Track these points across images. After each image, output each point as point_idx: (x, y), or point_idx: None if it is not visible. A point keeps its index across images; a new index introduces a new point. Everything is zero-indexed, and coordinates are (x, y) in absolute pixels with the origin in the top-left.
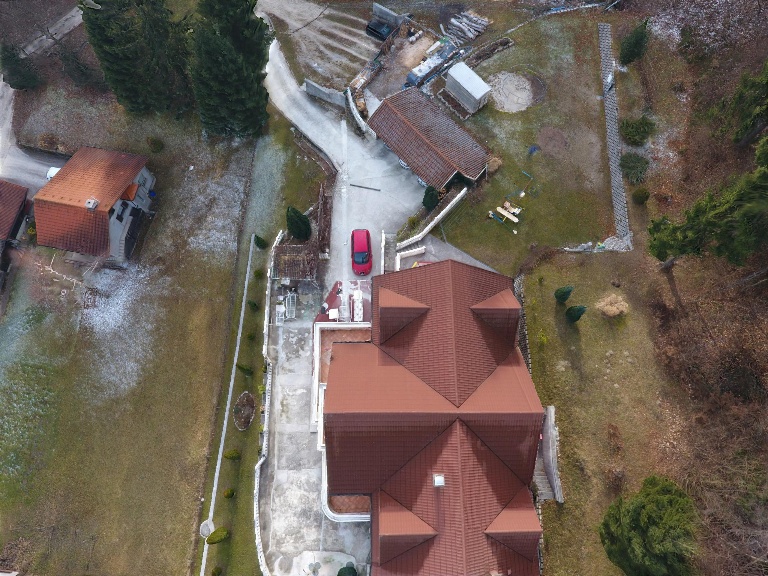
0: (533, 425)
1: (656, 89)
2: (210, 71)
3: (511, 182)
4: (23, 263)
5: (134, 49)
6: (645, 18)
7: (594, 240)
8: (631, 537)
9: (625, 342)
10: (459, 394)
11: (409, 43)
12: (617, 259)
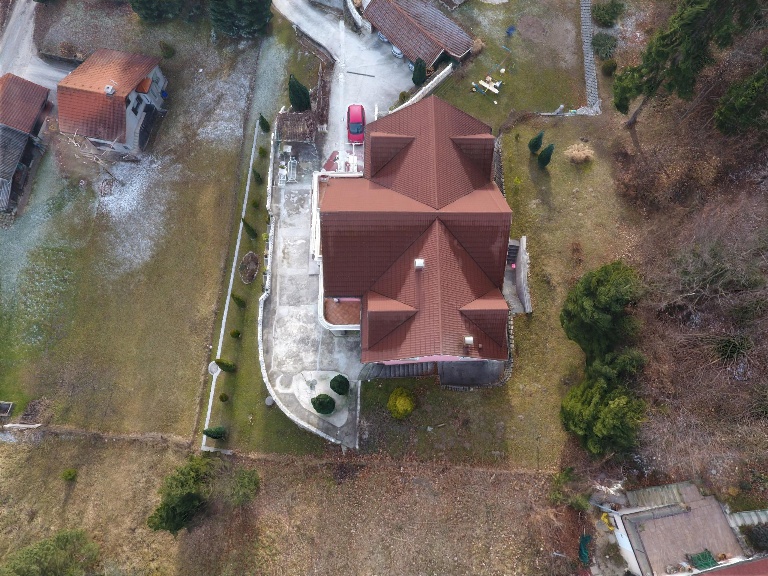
0: (503, 225)
1: None
2: None
3: (493, 62)
4: (44, 159)
5: None
6: None
7: (567, 110)
8: (583, 301)
9: (590, 181)
10: (439, 200)
11: None
12: (586, 121)
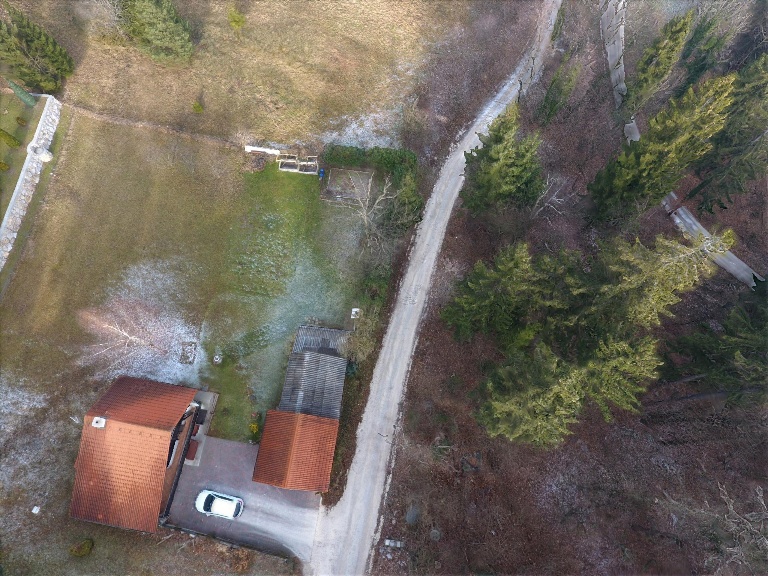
0: None
1: None
2: None
3: None
4: (277, 397)
5: None
6: None
7: None
8: None
9: None
10: None
11: None
12: None
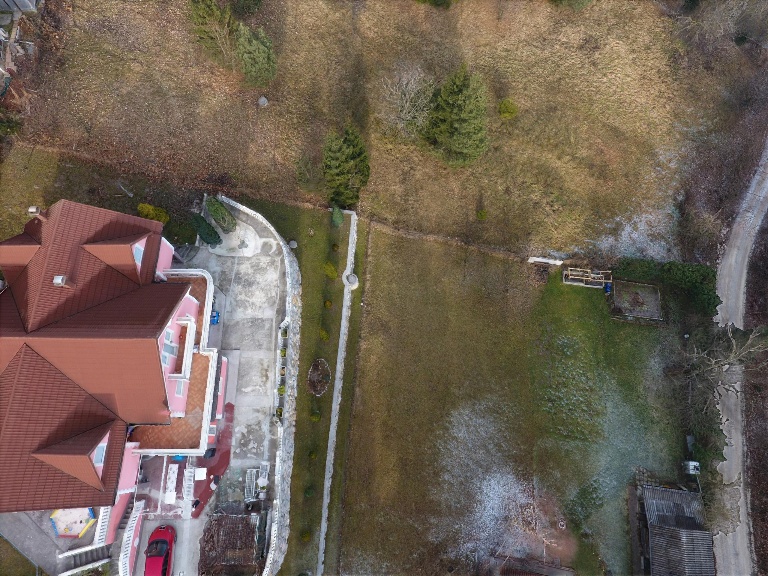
0: None
1: None
2: None
3: None
4: (628, 570)
5: None
6: None
7: None
8: None
9: None
10: (21, 356)
11: None
12: None
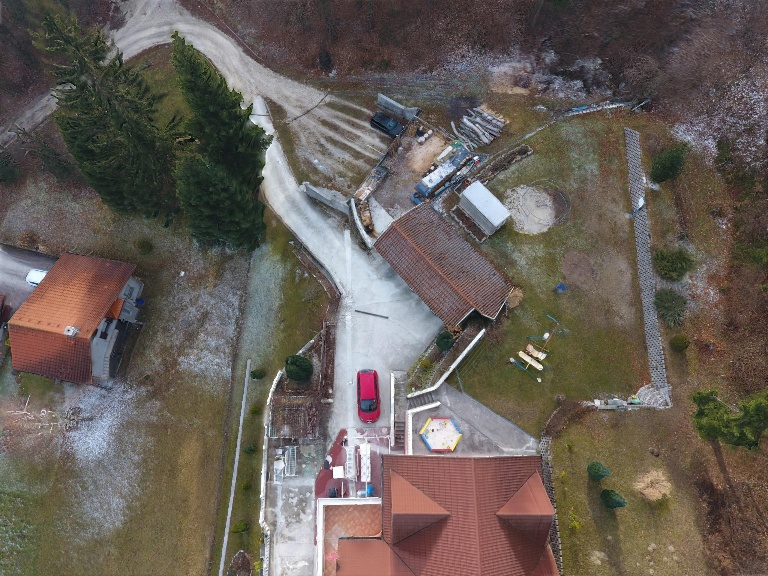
0: None
1: (692, 211)
2: (200, 198)
3: (533, 318)
4: (0, 375)
5: (117, 165)
6: (677, 125)
7: (627, 389)
8: None
9: (669, 533)
10: None
11: (418, 143)
12: (655, 419)
